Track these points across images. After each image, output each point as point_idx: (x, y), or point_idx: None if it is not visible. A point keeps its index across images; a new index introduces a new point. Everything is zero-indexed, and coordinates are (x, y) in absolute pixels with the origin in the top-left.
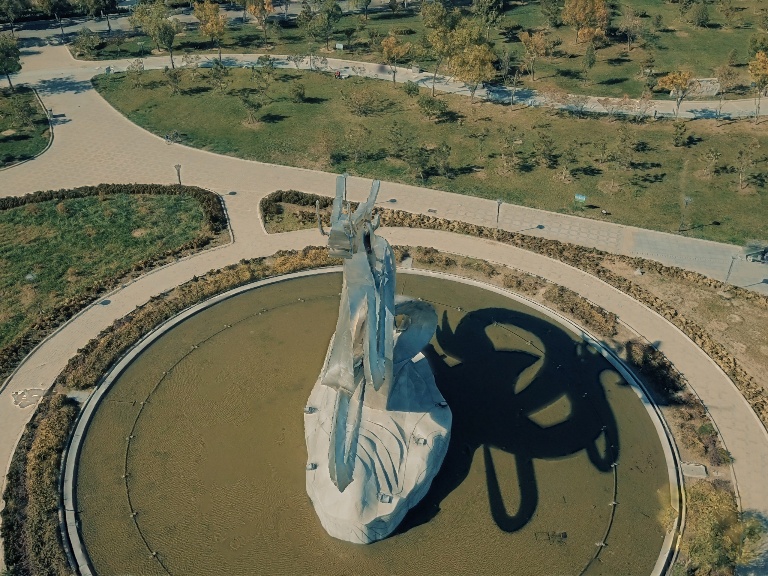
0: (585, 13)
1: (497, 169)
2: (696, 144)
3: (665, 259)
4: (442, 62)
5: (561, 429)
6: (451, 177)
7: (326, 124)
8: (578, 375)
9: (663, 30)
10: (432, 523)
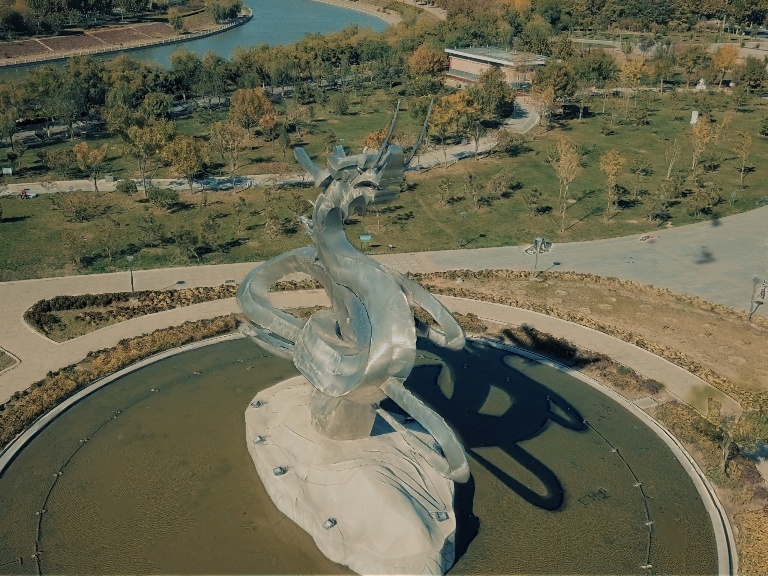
0: (254, 107)
1: (264, 237)
2: (416, 188)
3: (469, 268)
4: (131, 170)
5: (515, 412)
6: (224, 251)
7: (47, 235)
8: (486, 368)
9: (316, 120)
10: (482, 533)
